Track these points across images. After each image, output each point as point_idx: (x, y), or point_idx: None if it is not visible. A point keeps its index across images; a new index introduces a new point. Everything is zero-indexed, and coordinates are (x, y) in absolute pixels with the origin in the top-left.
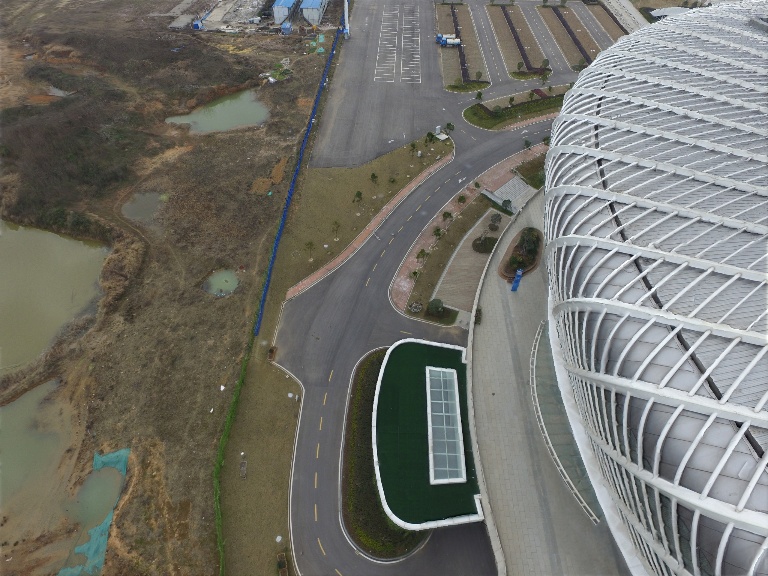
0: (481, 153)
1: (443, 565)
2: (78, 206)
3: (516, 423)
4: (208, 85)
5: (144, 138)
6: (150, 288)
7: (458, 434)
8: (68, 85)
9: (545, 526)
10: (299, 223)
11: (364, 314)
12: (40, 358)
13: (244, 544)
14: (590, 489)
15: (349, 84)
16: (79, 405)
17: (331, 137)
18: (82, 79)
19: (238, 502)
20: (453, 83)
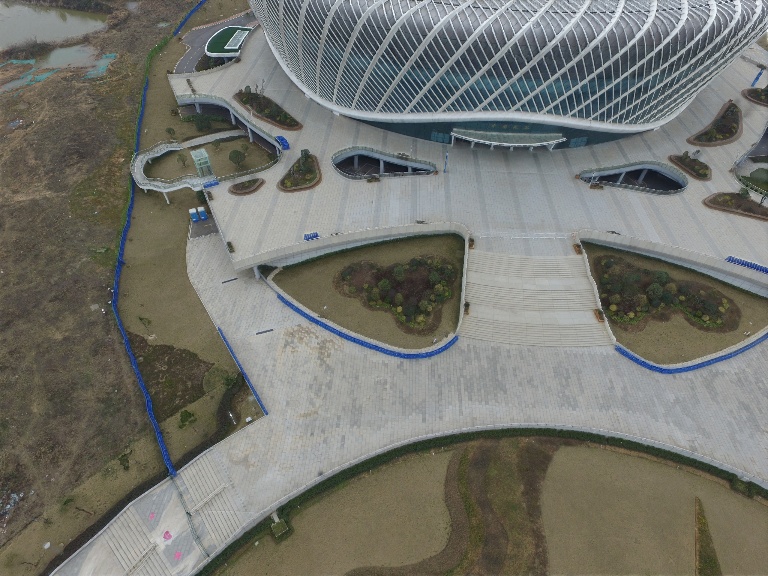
0: None
1: None
2: (97, 0)
3: None
4: None
5: None
6: None
7: None
8: None
9: (259, 53)
10: None
11: None
12: (81, 35)
13: (156, 70)
14: None
15: None
16: (97, 47)
17: None
18: None
19: (156, 64)
20: None
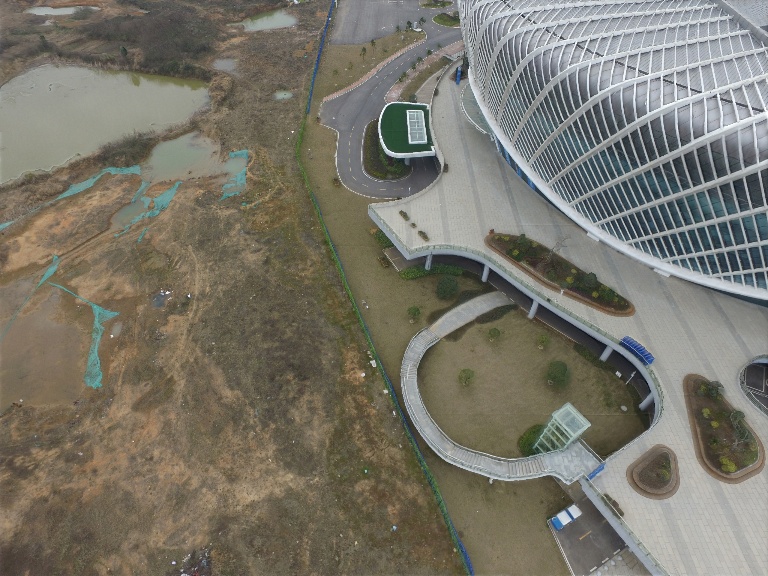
0: (444, 38)
1: (416, 182)
2: None
3: (454, 126)
4: (252, 4)
5: (216, 31)
6: (240, 96)
7: (423, 129)
8: (152, 6)
9: (465, 152)
10: (327, 69)
11: (370, 106)
12: (187, 120)
13: (315, 177)
14: (484, 126)
15: (352, 4)
16: (214, 138)
17: (342, 31)
18: (162, 2)
19: (309, 166)
20: (426, 3)
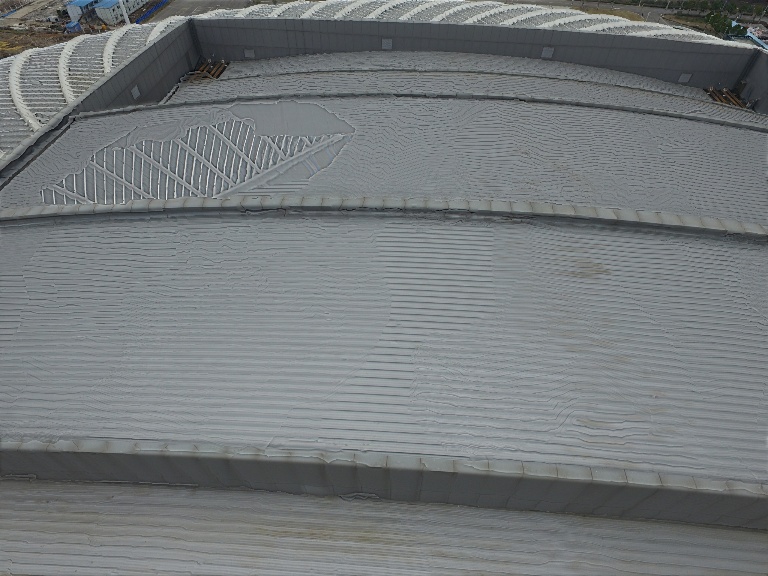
0: None
1: None
2: None
3: None
4: None
5: None
6: None
7: None
8: None
9: None
10: None
11: None
12: None
13: None
14: None
15: None
16: None
17: None
18: None
19: None
20: None
